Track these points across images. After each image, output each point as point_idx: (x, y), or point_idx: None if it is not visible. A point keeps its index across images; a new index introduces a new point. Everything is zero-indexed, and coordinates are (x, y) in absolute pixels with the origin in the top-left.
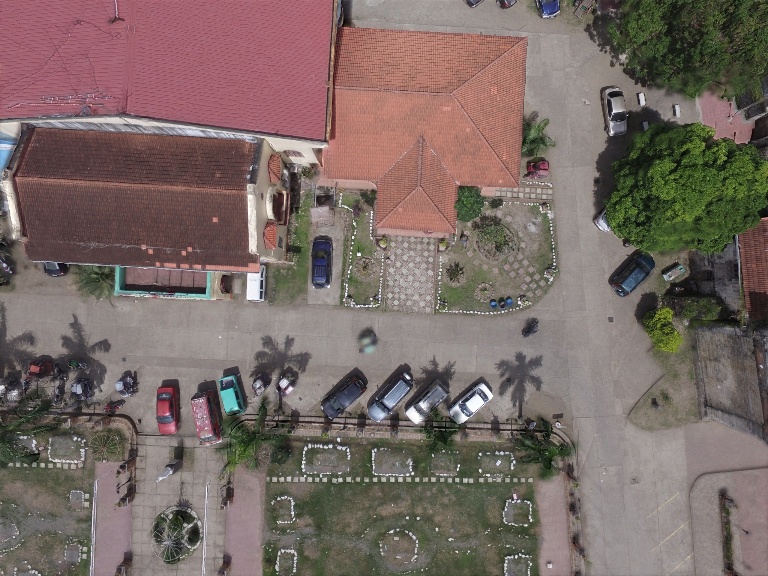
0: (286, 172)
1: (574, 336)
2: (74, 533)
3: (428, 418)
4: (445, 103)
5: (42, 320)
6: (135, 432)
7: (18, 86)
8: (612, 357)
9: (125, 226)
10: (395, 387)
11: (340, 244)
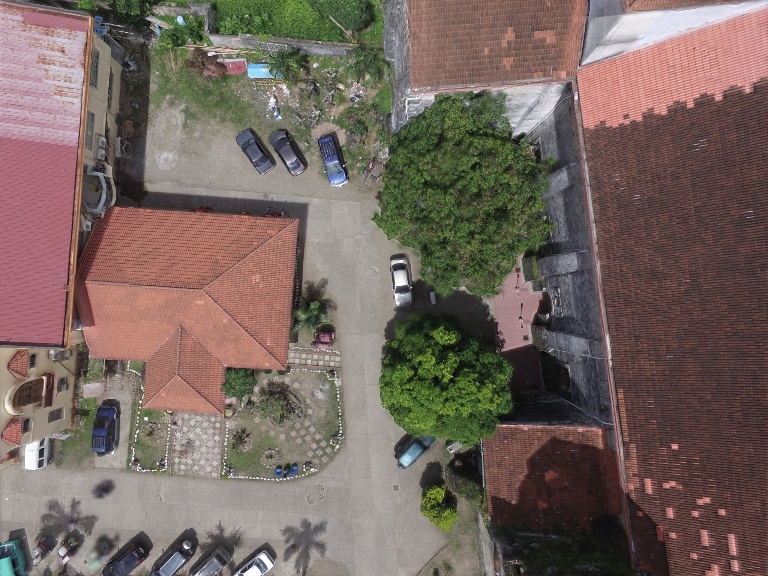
0: (53, 353)
1: (359, 504)
2: None
3: None
4: (197, 298)
5: None
6: None
7: None
8: (396, 525)
9: None
10: (170, 559)
11: (128, 408)
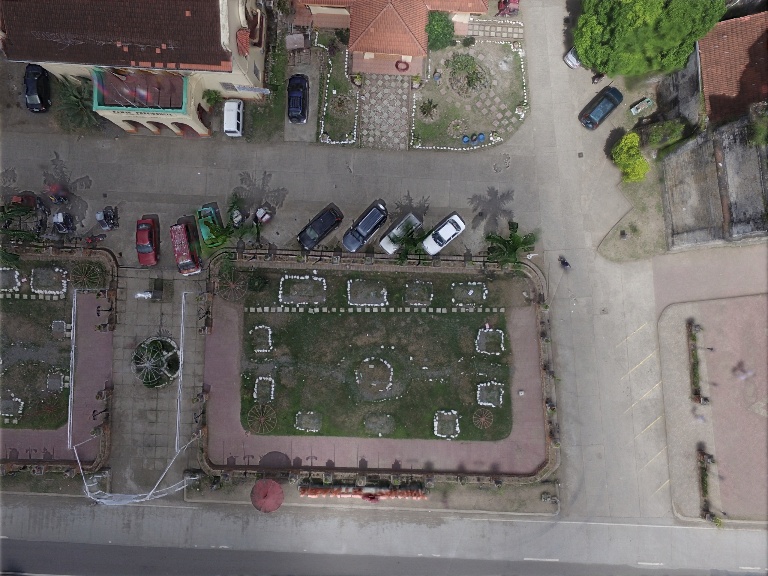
0: None
1: (545, 171)
2: (56, 362)
3: None
4: None
5: (24, 157)
6: (116, 264)
7: None
8: (582, 191)
9: (100, 21)
10: (369, 214)
11: (316, 82)
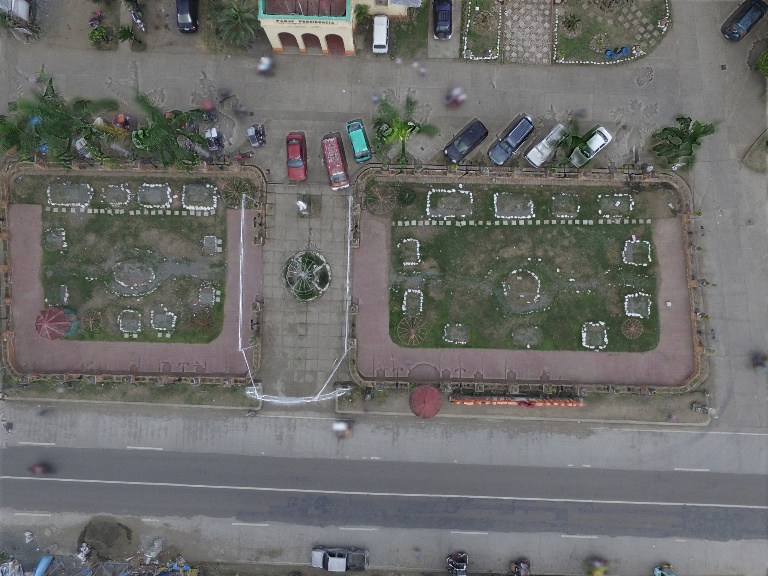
0: None
1: (688, 84)
2: (208, 277)
3: (547, 164)
4: None
5: (172, 77)
6: (264, 180)
7: None
8: (726, 103)
9: None
10: (519, 125)
11: None
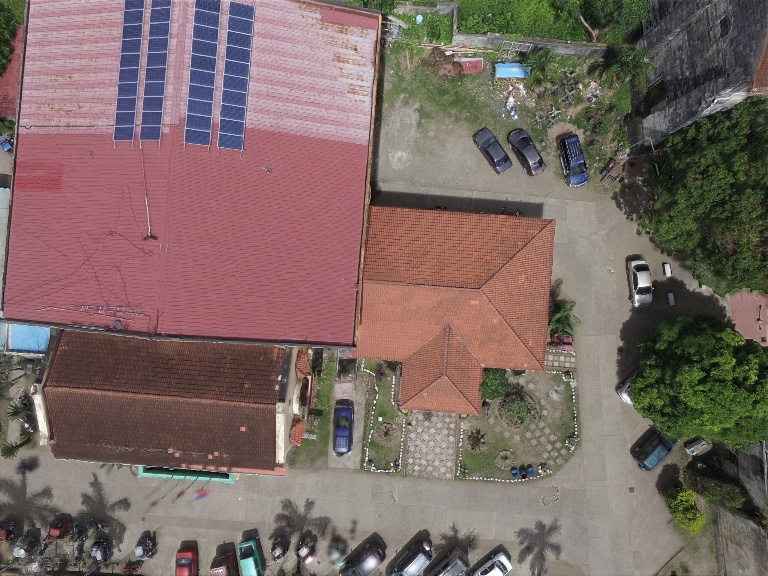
0: (311, 352)
1: (594, 506)
2: None
3: None
4: (473, 297)
5: (62, 478)
6: None
7: (48, 289)
8: (632, 528)
9: (152, 432)
10: (415, 561)
11: (361, 408)
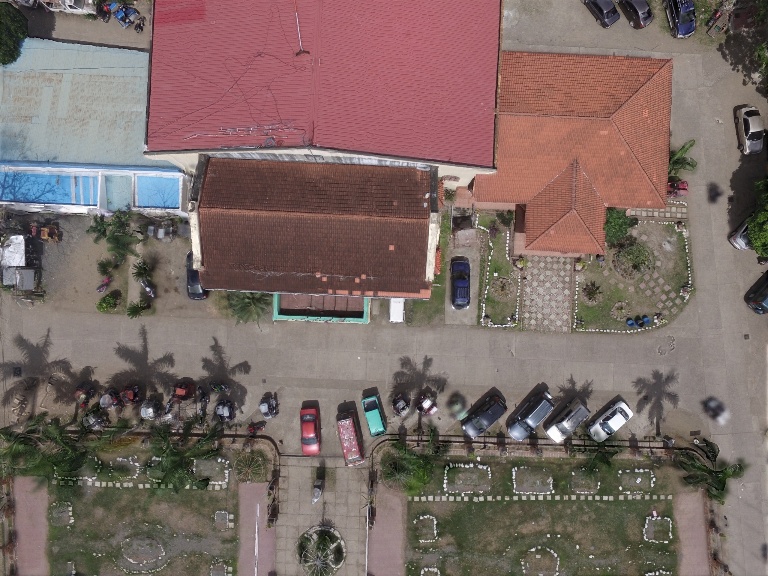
0: None
1: (710, 353)
2: (219, 553)
3: (567, 436)
4: (603, 127)
5: (183, 343)
6: (277, 453)
7: (194, 117)
8: (748, 374)
9: (302, 254)
10: (539, 407)
11: (476, 264)
